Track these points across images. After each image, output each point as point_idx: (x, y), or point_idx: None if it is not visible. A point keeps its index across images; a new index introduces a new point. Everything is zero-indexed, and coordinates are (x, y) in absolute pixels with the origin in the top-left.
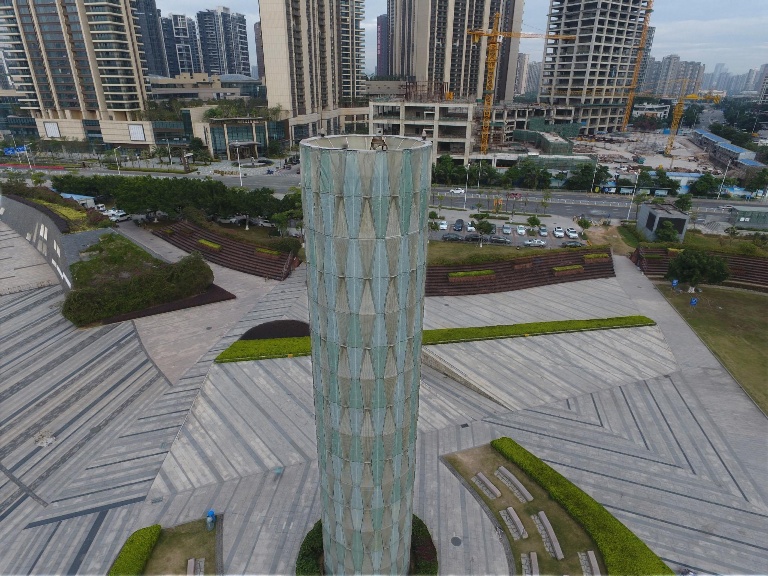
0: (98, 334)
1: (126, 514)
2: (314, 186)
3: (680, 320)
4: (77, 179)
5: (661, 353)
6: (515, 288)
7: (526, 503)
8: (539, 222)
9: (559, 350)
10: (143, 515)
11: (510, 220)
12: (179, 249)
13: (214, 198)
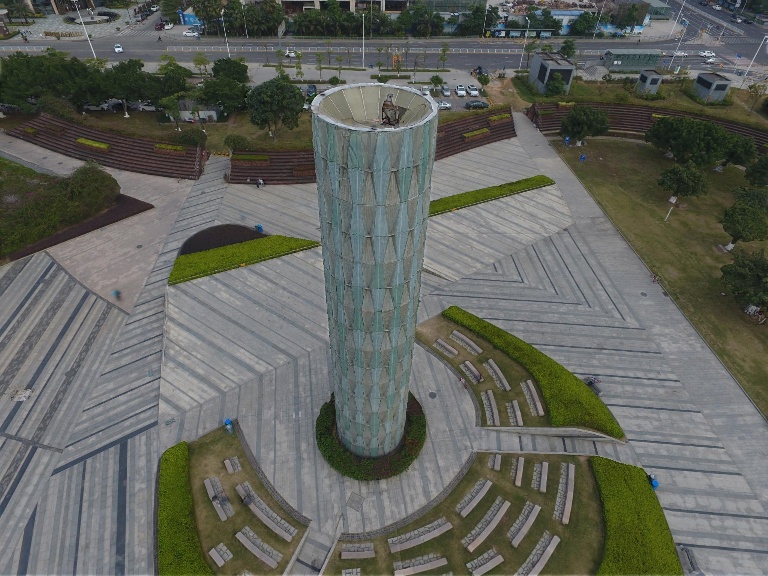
0: (12, 273)
1: (146, 440)
2: (340, 161)
3: (571, 175)
4: None
5: (560, 209)
6: None
7: (478, 355)
8: (442, 81)
9: (482, 220)
10: (163, 437)
11: (412, 79)
12: (54, 152)
13: (77, 83)
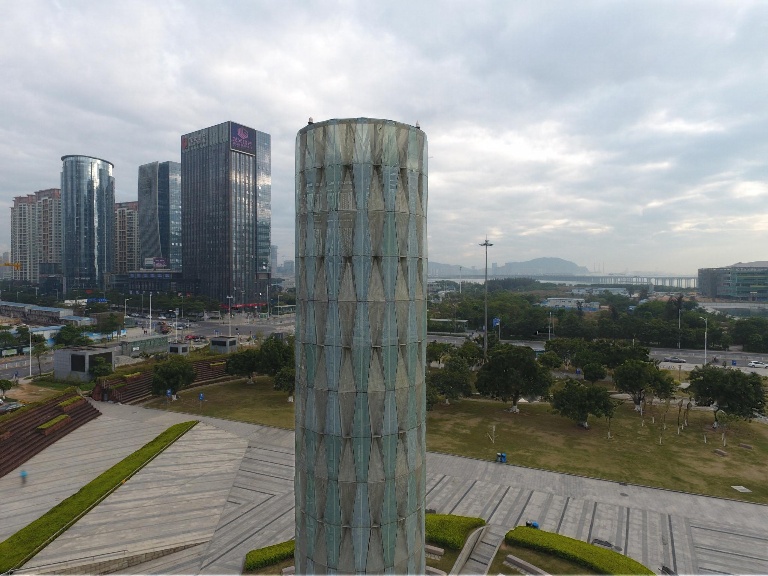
0: None
1: None
2: None
3: (198, 417)
4: None
5: (226, 437)
6: (13, 466)
7: None
8: None
9: (167, 475)
10: None
11: None
12: None
13: None
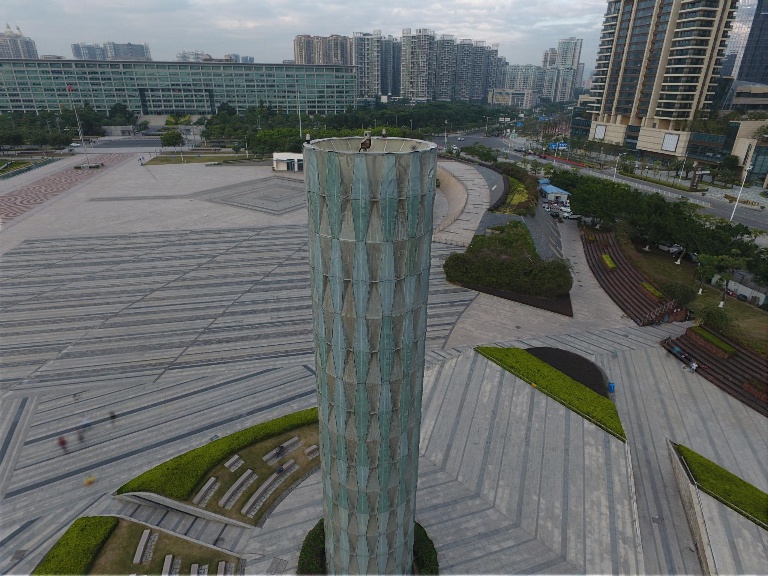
0: (451, 290)
1: None
2: None
3: None
4: (567, 175)
5: None
6: None
7: None
8: None
9: None
10: None
11: None
12: (584, 257)
13: (650, 218)
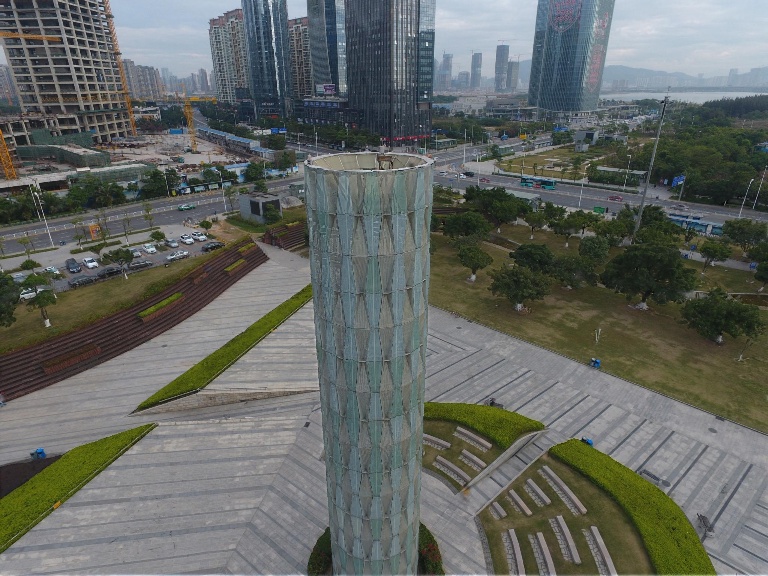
0: None
1: None
2: (382, 210)
3: None
4: None
5: None
6: (209, 300)
7: None
8: (164, 235)
9: (303, 328)
10: None
11: (126, 243)
12: None
13: None
